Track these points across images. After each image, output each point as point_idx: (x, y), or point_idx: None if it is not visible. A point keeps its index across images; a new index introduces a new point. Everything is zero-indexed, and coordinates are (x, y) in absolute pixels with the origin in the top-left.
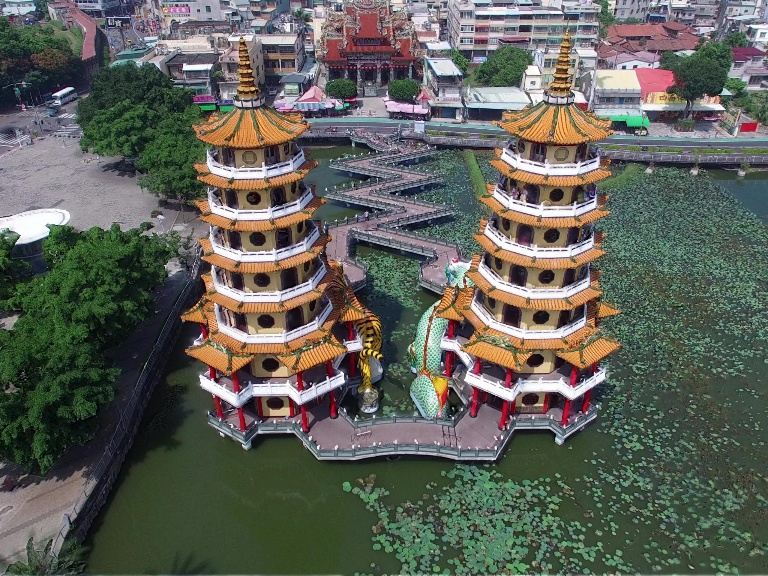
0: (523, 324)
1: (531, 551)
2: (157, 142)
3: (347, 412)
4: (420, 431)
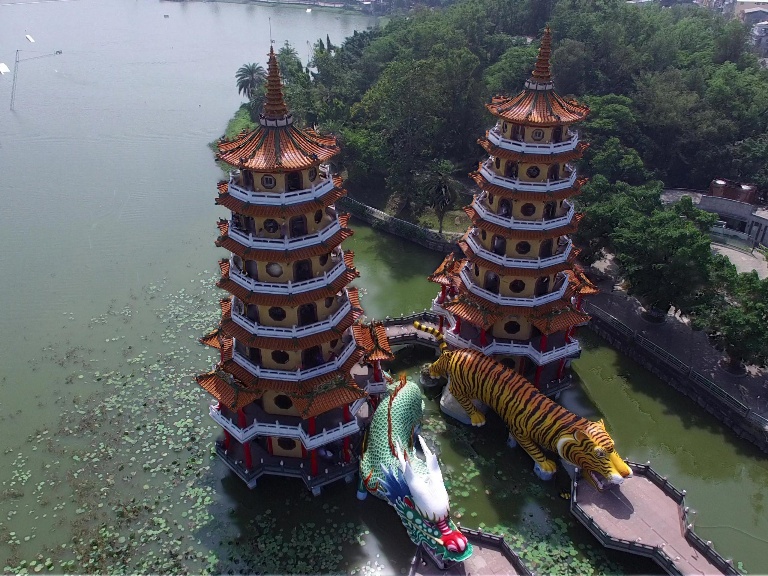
0: None
1: None
2: None
3: None
4: None
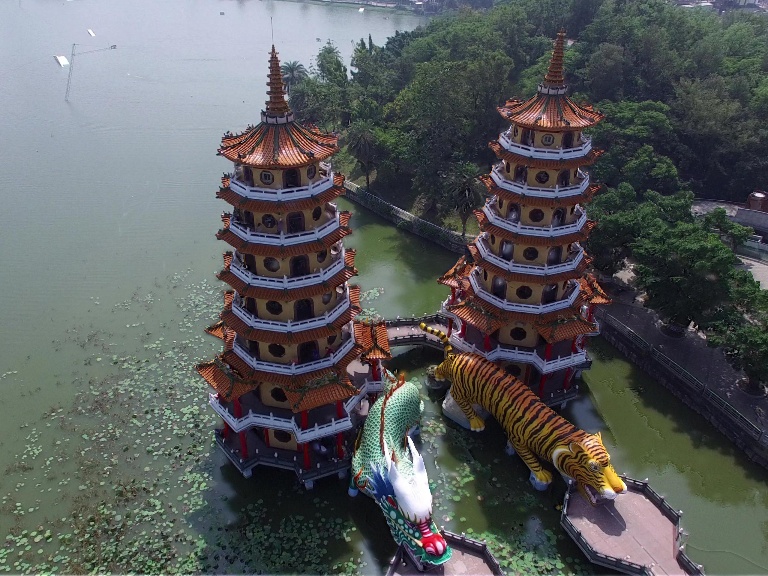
0: None
1: None
2: None
3: None
4: None
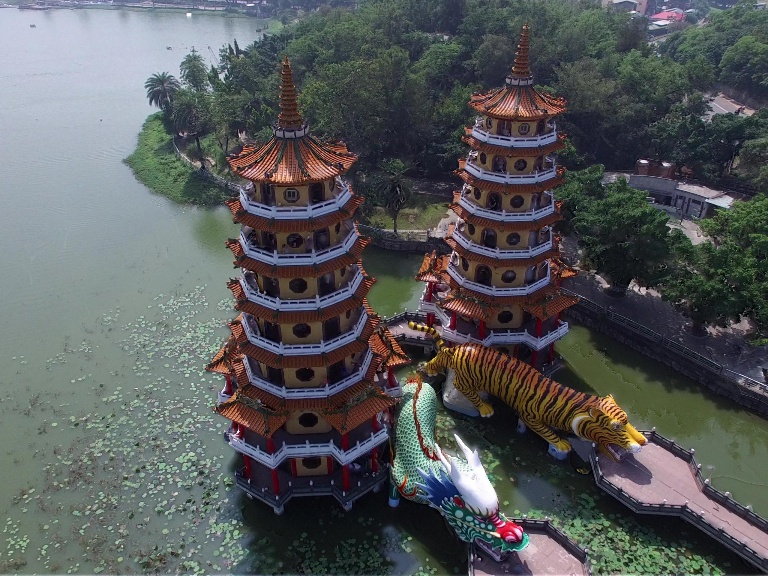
0: None
1: None
2: None
3: None
4: None
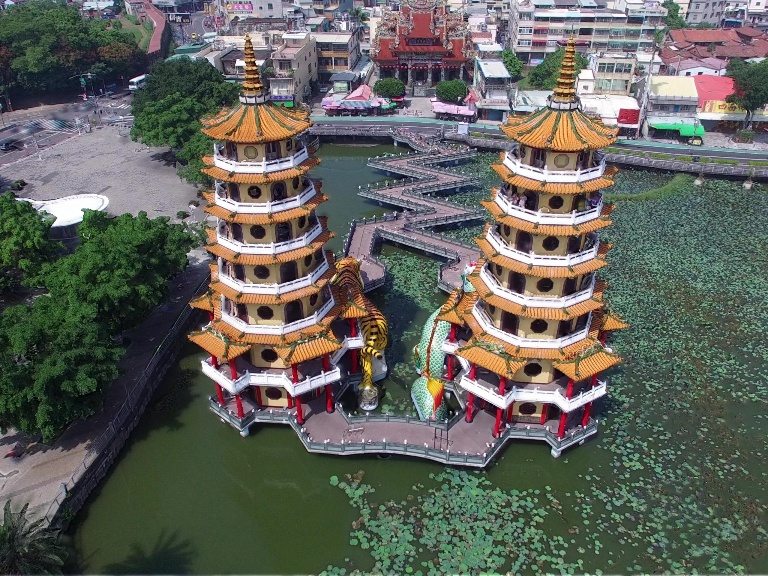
0: (521, 332)
1: (508, 562)
2: (197, 134)
3: (346, 407)
4: (412, 432)
